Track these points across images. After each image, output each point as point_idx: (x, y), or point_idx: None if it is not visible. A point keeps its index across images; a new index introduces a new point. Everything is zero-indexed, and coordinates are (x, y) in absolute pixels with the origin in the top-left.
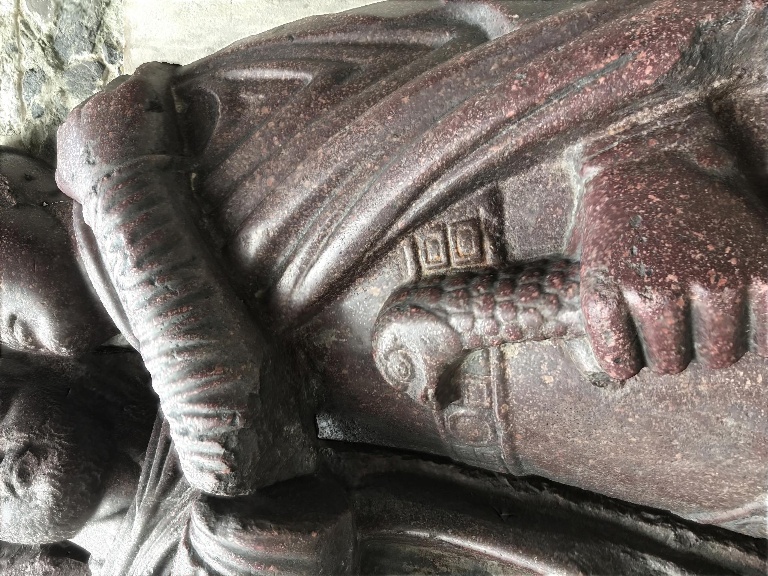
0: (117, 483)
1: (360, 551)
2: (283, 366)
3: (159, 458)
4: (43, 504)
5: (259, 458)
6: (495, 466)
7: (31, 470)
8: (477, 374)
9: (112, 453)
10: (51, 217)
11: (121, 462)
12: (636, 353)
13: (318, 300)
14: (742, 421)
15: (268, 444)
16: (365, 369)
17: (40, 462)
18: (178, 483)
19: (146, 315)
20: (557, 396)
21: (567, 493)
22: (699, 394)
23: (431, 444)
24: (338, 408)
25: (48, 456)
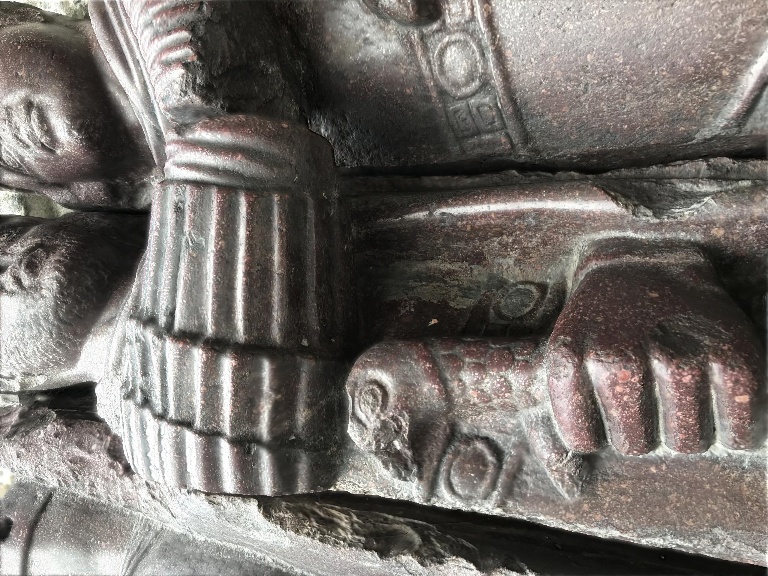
0: (124, 285)
1: (356, 244)
2: (261, 11)
3: None
4: (47, 293)
5: (229, 62)
6: (496, 135)
7: (39, 263)
8: None
9: (122, 264)
10: (74, 31)
11: (130, 270)
12: None
13: None
14: None
15: (241, 60)
16: (347, 26)
17: (48, 256)
18: None
19: None
20: None
21: (584, 173)
22: None
23: (428, 132)
24: (327, 99)
25: (57, 251)
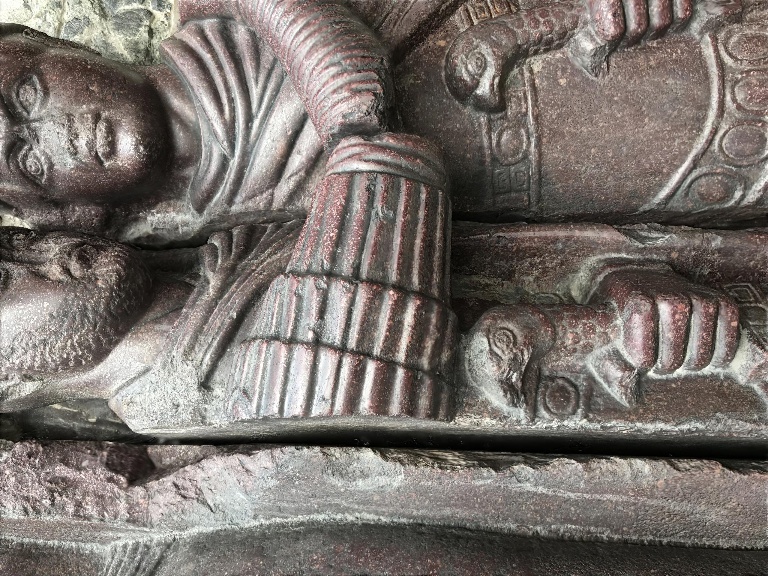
0: (167, 290)
1: None
2: None
3: (226, 243)
4: (104, 283)
5: None
6: (522, 194)
7: (90, 257)
8: (516, 87)
9: (156, 274)
10: None
11: (166, 280)
12: (623, 12)
13: (409, 38)
14: (677, 79)
15: None
16: (434, 104)
17: (99, 252)
18: (251, 254)
19: (307, 7)
20: (569, 92)
21: None
22: (651, 67)
23: (472, 187)
24: None
25: None
